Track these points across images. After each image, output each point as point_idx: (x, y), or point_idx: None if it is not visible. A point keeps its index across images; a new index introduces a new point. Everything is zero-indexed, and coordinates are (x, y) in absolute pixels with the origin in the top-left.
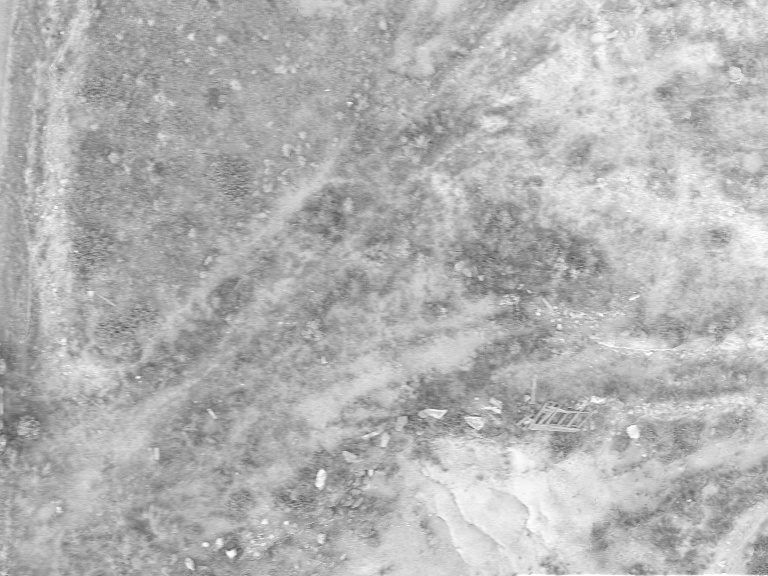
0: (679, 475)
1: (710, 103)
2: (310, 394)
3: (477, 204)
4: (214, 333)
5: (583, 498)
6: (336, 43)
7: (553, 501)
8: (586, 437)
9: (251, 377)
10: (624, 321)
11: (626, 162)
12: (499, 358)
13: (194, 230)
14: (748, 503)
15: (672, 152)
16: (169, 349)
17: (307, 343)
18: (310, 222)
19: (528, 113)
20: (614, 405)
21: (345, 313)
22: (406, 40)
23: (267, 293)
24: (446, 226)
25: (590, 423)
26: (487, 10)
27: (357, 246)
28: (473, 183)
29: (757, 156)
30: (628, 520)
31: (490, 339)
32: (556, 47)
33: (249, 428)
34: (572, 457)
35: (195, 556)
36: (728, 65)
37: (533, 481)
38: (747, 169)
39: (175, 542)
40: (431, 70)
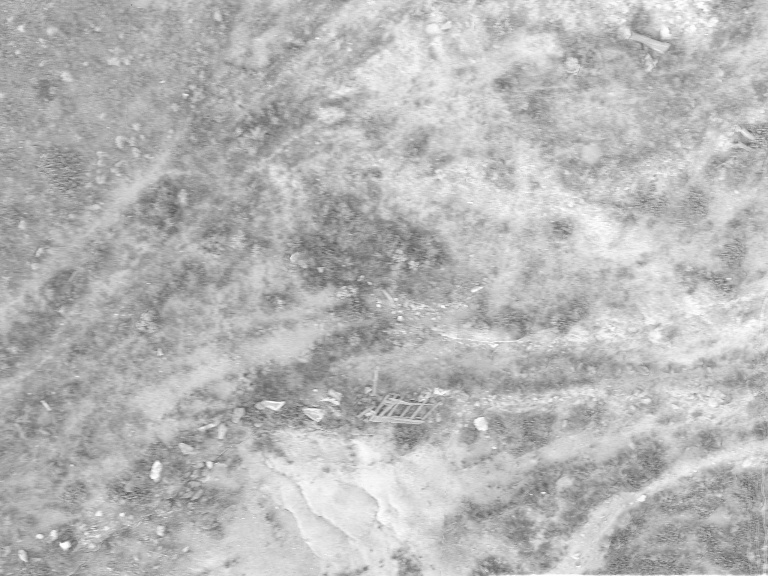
0: (533, 467)
1: (549, 94)
2: (146, 386)
3: (316, 196)
4: (48, 325)
5: (433, 490)
6: (171, 35)
7: (401, 493)
8: (432, 429)
9: (86, 369)
10: (466, 313)
11: (464, 153)
12: (339, 350)
13: (24, 222)
14: (603, 495)
15: (510, 143)
16: (2, 341)
17: (142, 335)
18: (146, 214)
19: (366, 104)
20: (459, 397)
21: (182, 305)
22: (242, 32)
23: (103, 285)
24: (284, 218)
25: (436, 415)
26: (322, 1)
27: (194, 238)
28: (311, 175)
29: (596, 147)
30: (480, 512)
31: (330, 331)
32: (391, 38)
33: (84, 420)
34: (419, 449)
35: (28, 548)
36: (567, 56)
37: (380, 473)
38: (586, 160)
39: (9, 534)
40: (265, 61)
